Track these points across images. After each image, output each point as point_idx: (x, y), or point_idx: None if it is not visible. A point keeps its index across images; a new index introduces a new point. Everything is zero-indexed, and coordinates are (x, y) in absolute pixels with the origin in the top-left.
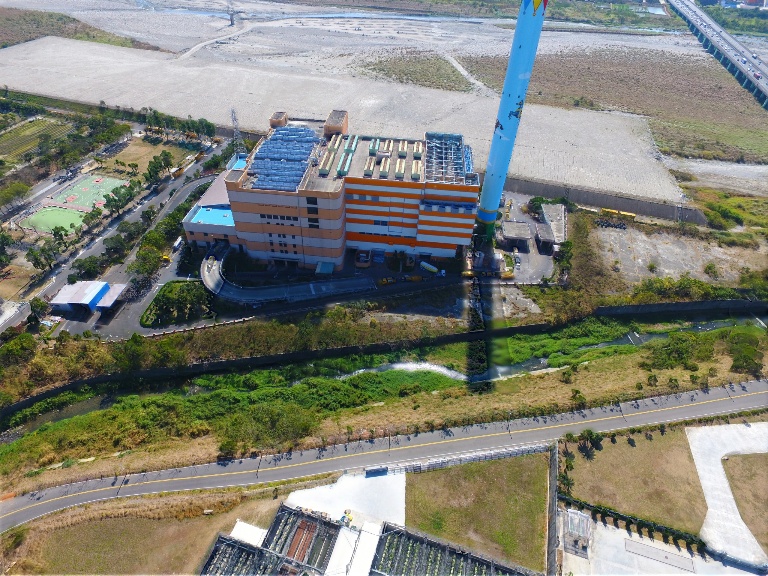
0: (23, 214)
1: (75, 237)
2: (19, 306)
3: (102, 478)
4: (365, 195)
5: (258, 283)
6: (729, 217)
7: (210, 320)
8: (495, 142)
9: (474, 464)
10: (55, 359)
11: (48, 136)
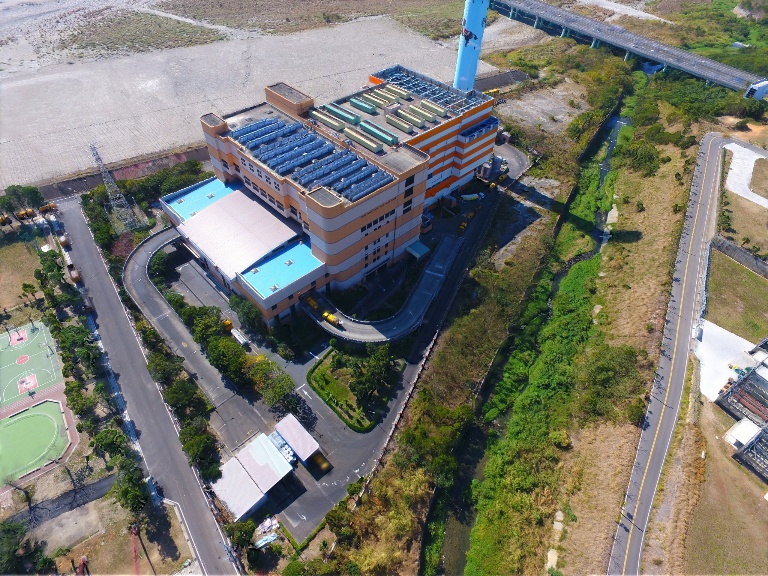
0: None
1: (85, 443)
2: (229, 556)
3: (615, 538)
4: None
5: (400, 302)
6: (530, 68)
7: (408, 368)
8: (468, 55)
9: (710, 283)
10: (366, 545)
11: None
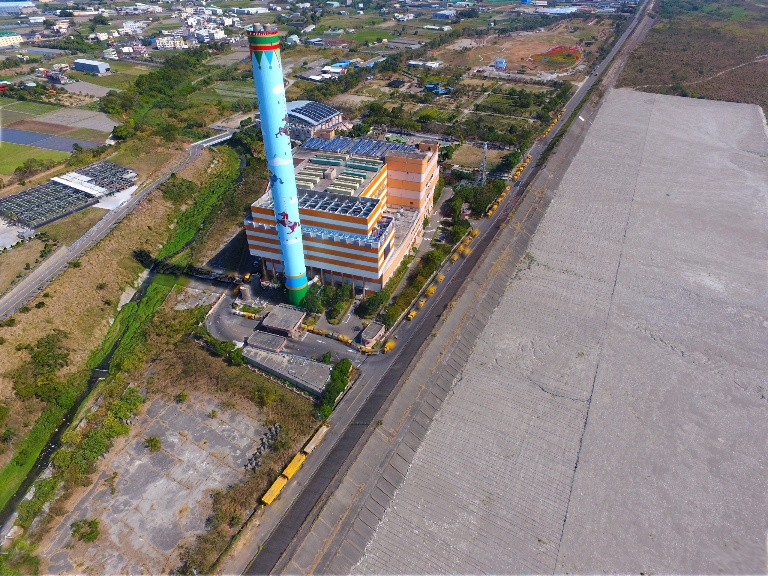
0: (400, 135)
1: None
2: None
3: None
4: None
5: None
6: None
7: None
8: None
9: None
10: None
11: (482, 120)
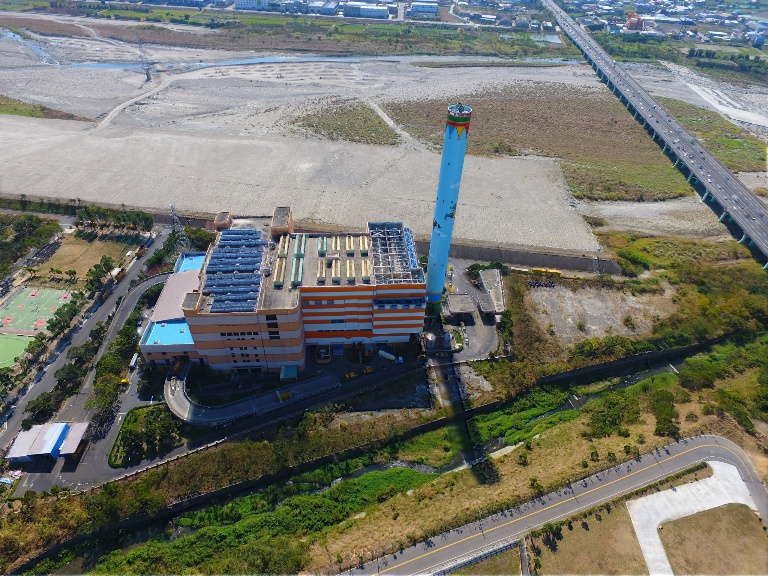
0: None
1: (20, 369)
2: None
3: None
4: (320, 300)
5: (225, 400)
6: (637, 263)
7: (182, 448)
8: (434, 237)
9: (456, 573)
10: (24, 525)
11: None
